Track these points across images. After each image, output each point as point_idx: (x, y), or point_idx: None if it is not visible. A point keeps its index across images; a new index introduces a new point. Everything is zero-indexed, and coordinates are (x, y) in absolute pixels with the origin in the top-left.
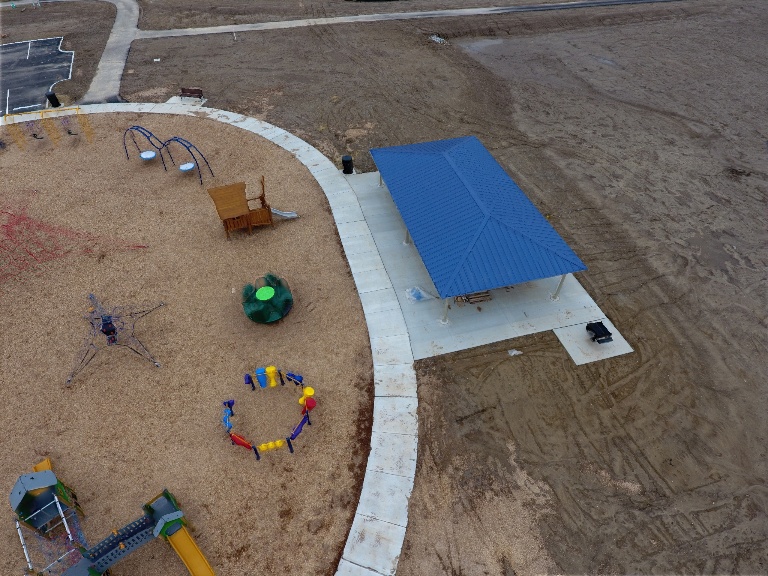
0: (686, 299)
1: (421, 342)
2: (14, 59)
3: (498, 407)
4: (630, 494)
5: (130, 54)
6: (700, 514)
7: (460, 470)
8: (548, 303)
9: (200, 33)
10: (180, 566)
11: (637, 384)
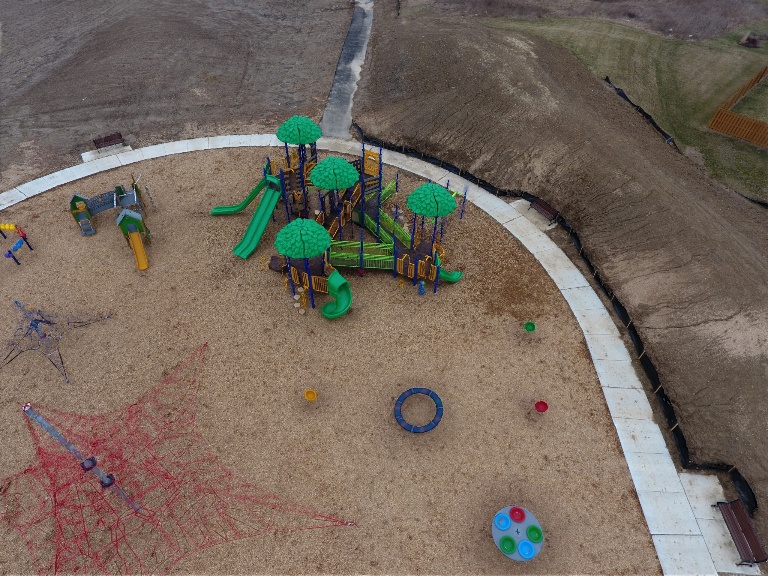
0: None
1: None
2: None
3: None
4: None
5: None
6: None
7: None
8: None
9: None
10: None
11: None
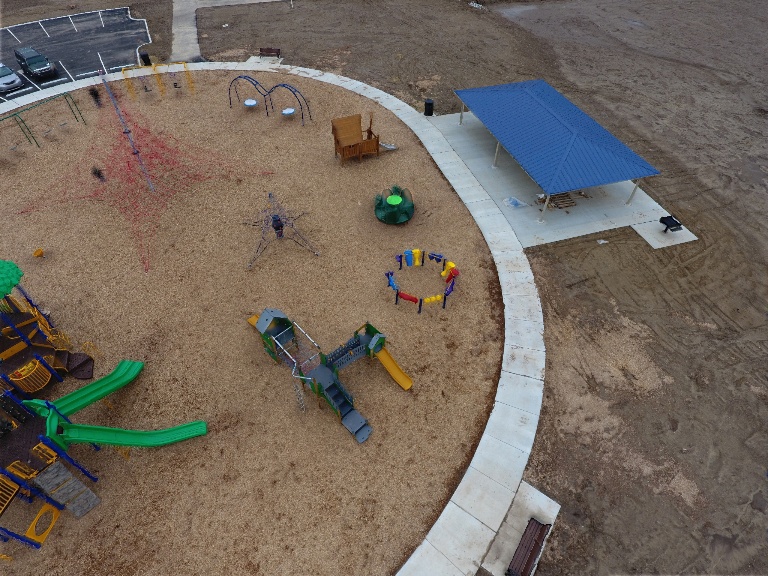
0: (734, 205)
1: (525, 236)
2: (91, 27)
3: (597, 277)
4: (710, 330)
5: (198, 21)
6: (765, 342)
7: (577, 317)
8: (623, 207)
9: (256, 2)
10: (382, 377)
11: (704, 261)
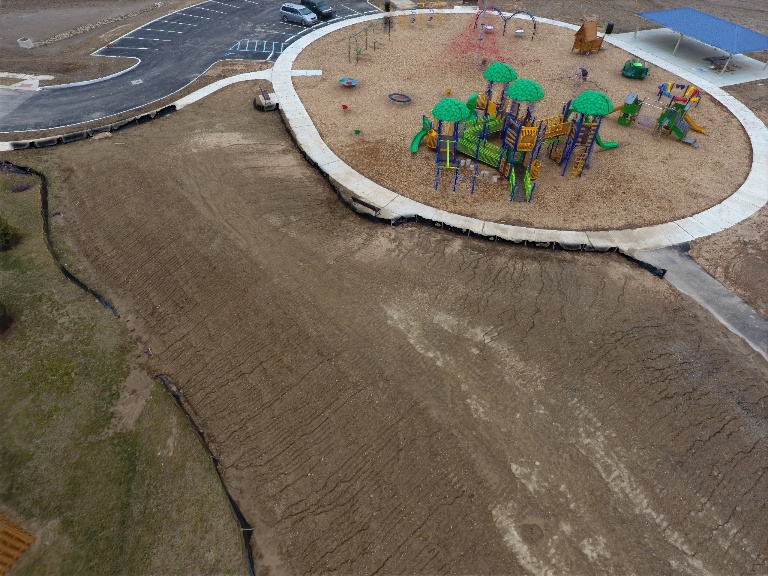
0: None
1: None
2: None
3: (767, 97)
4: None
5: None
6: None
7: (767, 110)
8: (762, 71)
9: None
10: None
11: None
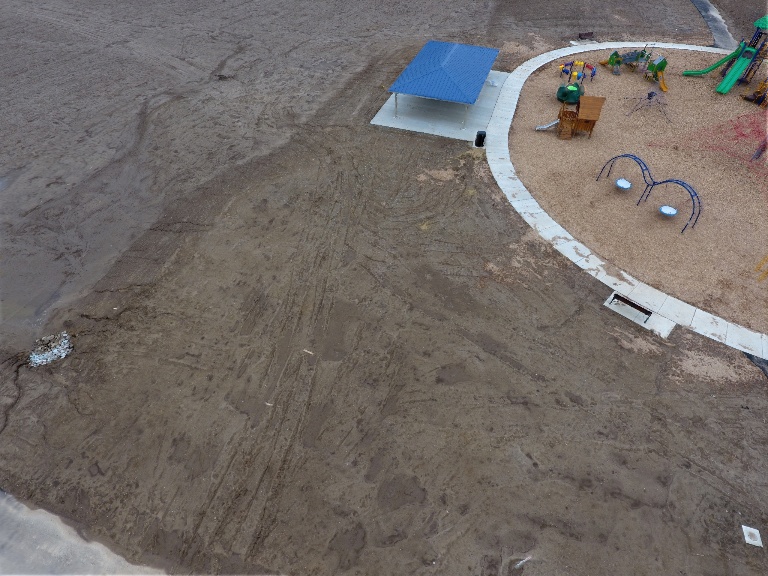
0: None
1: (504, 75)
2: None
3: None
4: None
5: None
6: None
7: None
8: None
9: None
10: None
11: None
